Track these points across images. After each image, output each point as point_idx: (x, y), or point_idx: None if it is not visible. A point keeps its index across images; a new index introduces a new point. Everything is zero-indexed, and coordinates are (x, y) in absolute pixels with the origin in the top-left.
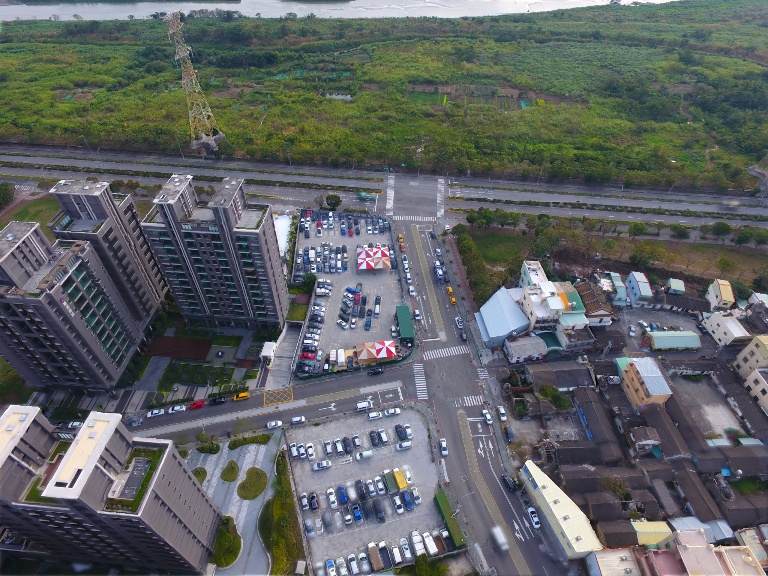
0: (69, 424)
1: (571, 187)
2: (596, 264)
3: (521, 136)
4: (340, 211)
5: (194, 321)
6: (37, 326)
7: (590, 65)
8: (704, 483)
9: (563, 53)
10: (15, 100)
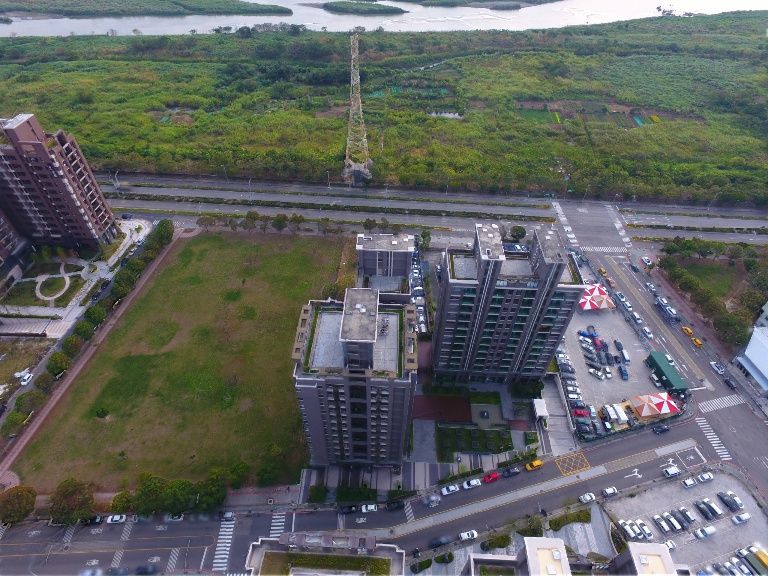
0: (362, 508)
1: (743, 211)
2: None
3: (656, 155)
4: (523, 243)
5: (440, 376)
6: (378, 407)
7: (683, 79)
8: None
9: (651, 67)
10: (113, 124)
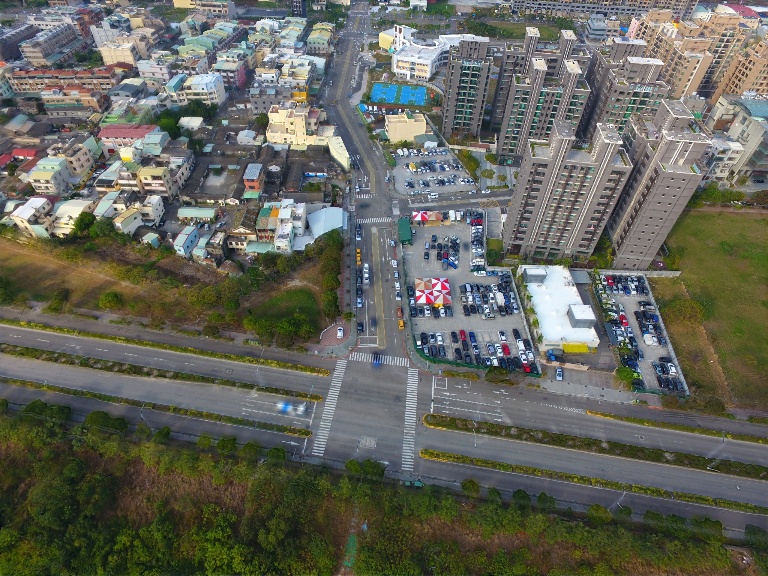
0: None
1: None
2: (193, 282)
3: None
4: None
5: None
6: None
7: None
8: (259, 156)
9: None
10: None
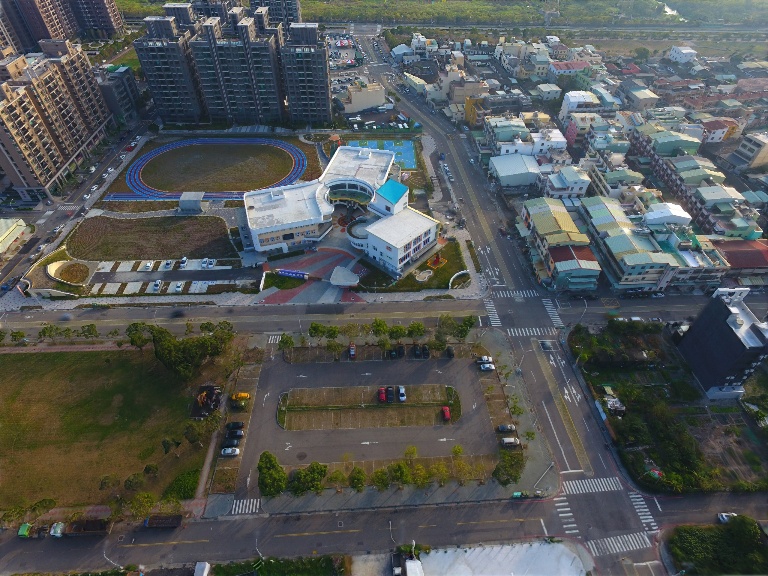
0: None
1: (449, 25)
2: None
3: None
4: None
5: None
6: None
7: None
8: None
9: None
10: None
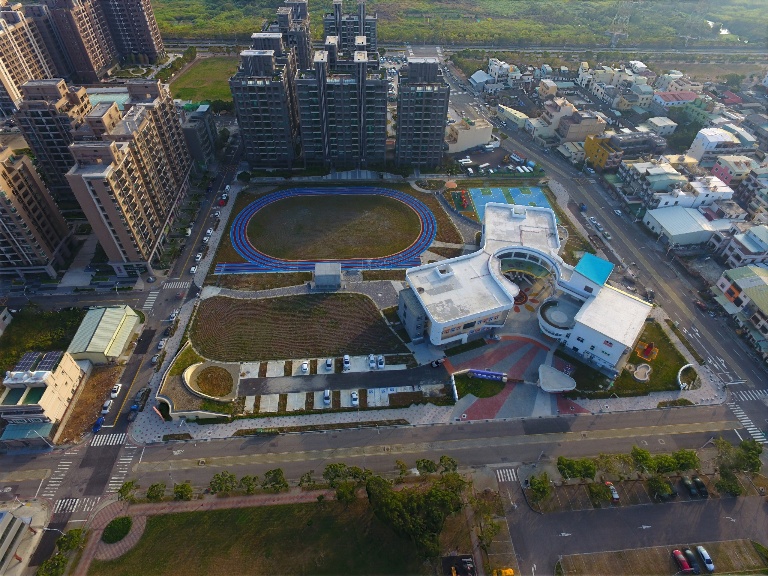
0: None
1: (511, 47)
2: None
3: (480, 33)
4: None
5: None
6: None
7: (519, 3)
8: None
9: None
10: None
